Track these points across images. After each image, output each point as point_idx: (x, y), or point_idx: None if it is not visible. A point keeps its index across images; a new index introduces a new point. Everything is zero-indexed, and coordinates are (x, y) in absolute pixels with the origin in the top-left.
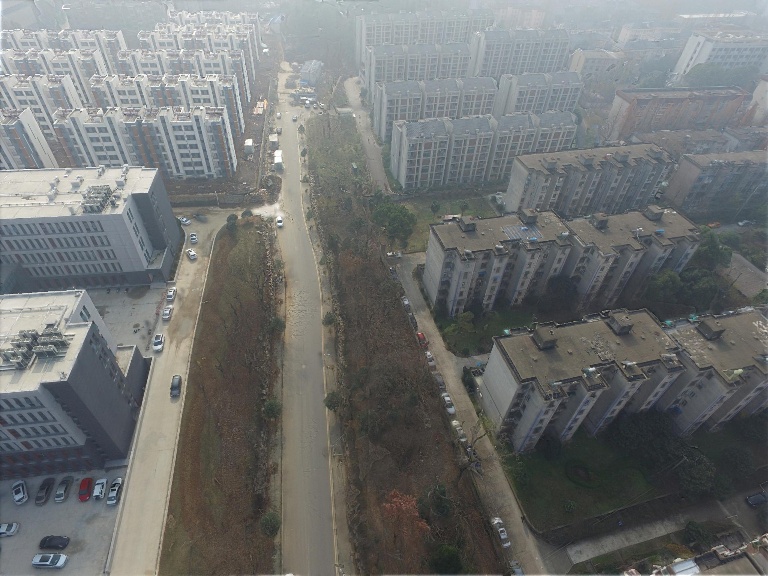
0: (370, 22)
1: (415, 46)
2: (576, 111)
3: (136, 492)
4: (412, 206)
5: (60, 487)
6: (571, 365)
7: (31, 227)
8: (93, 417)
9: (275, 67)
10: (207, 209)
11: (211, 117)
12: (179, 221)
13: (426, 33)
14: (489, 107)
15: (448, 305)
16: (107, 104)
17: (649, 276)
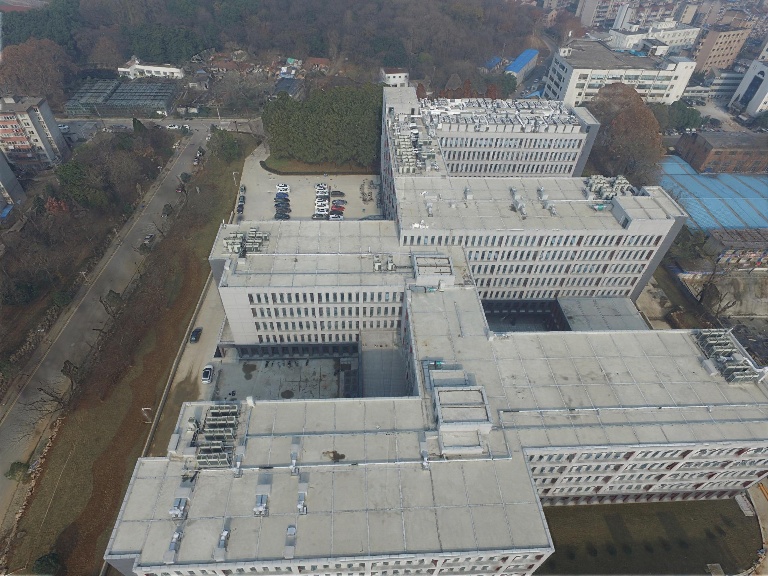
0: None
1: None
2: None
3: None
4: None
5: None
6: None
7: None
8: None
9: None
10: None
11: None
12: None
13: None
14: None
15: None
16: None
17: None
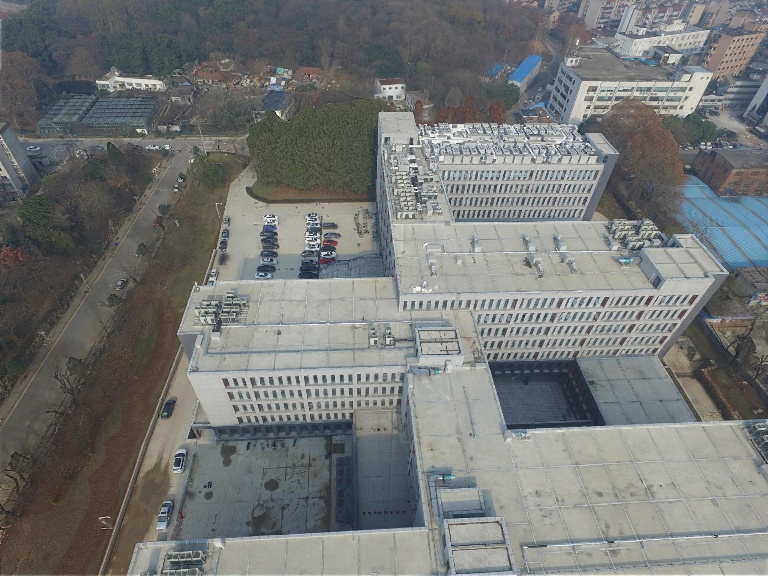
0: None
1: None
2: None
3: None
4: None
5: None
6: None
7: None
8: None
9: None
10: None
11: None
12: None
13: None
14: None
15: None
16: None
17: None
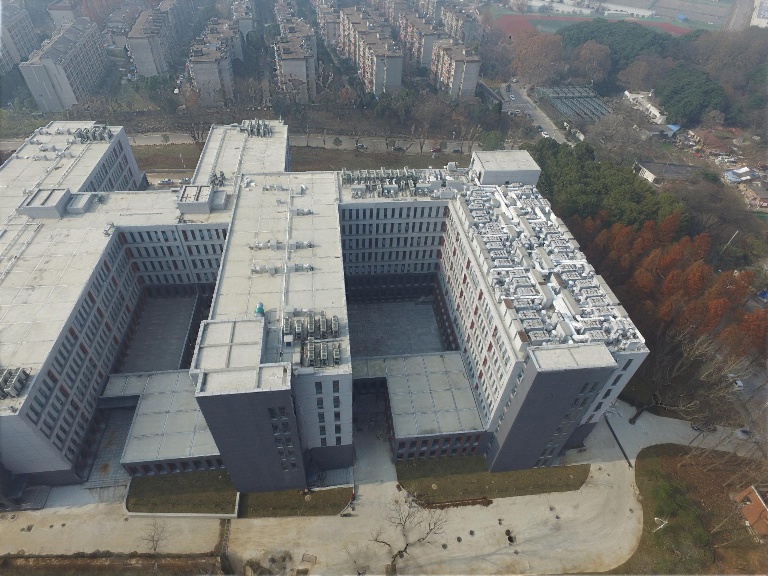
0: None
1: None
2: (38, 34)
3: None
4: None
5: None
6: None
7: (102, 170)
8: None
9: None
10: None
11: None
12: None
13: None
14: (6, 50)
15: None
16: None
17: None
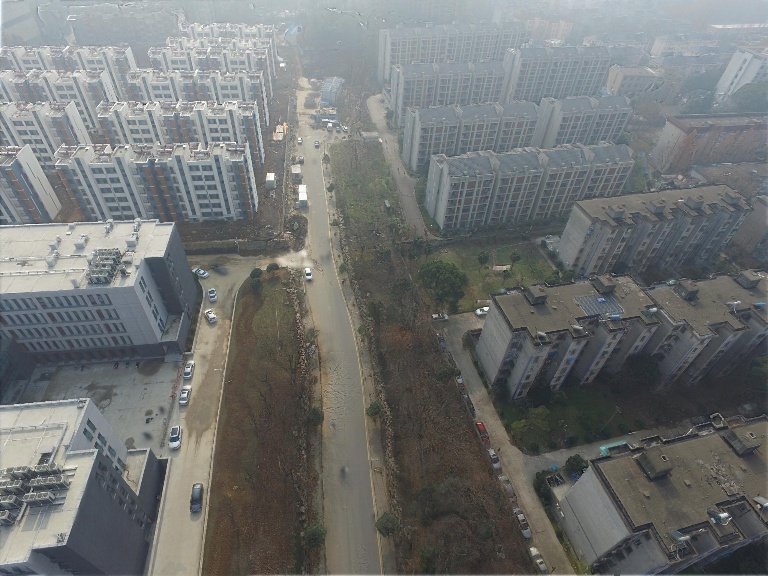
0: (395, 37)
1: (446, 65)
2: (622, 137)
3: None
4: (454, 253)
5: None
6: (692, 504)
7: (27, 301)
8: (99, 570)
9: (293, 84)
10: (226, 257)
11: (232, 155)
12: (196, 276)
13: (453, 48)
14: (530, 134)
15: (510, 386)
16: (115, 134)
17: (743, 353)
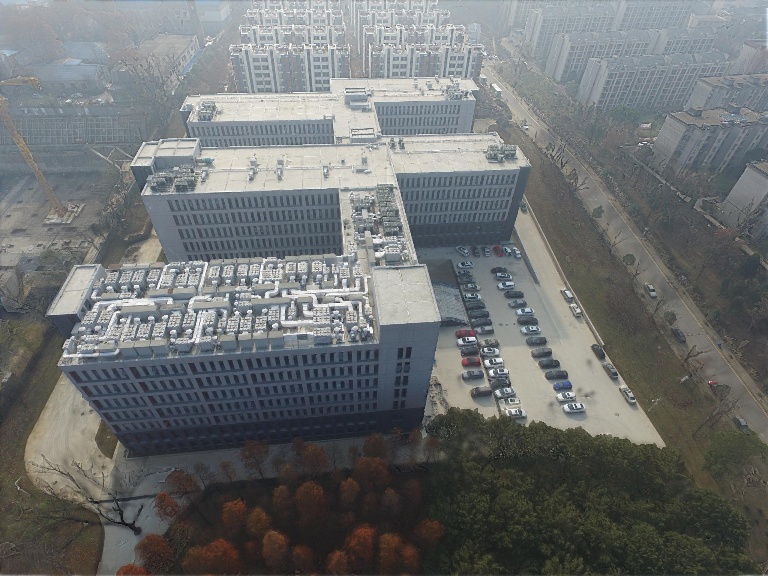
0: None
1: (572, 8)
2: None
3: (530, 252)
4: None
5: (486, 249)
6: None
7: (418, 109)
8: (521, 199)
9: None
10: None
11: None
12: None
13: (562, 1)
14: None
15: (675, 170)
16: None
17: None
